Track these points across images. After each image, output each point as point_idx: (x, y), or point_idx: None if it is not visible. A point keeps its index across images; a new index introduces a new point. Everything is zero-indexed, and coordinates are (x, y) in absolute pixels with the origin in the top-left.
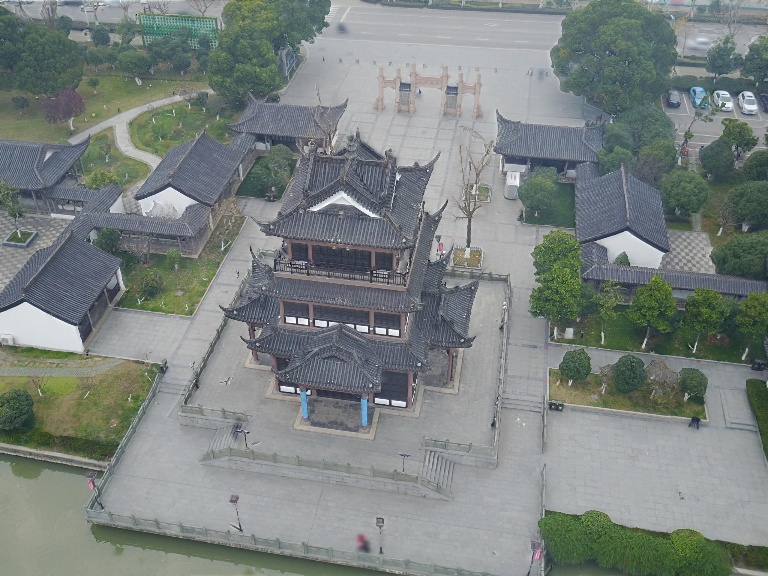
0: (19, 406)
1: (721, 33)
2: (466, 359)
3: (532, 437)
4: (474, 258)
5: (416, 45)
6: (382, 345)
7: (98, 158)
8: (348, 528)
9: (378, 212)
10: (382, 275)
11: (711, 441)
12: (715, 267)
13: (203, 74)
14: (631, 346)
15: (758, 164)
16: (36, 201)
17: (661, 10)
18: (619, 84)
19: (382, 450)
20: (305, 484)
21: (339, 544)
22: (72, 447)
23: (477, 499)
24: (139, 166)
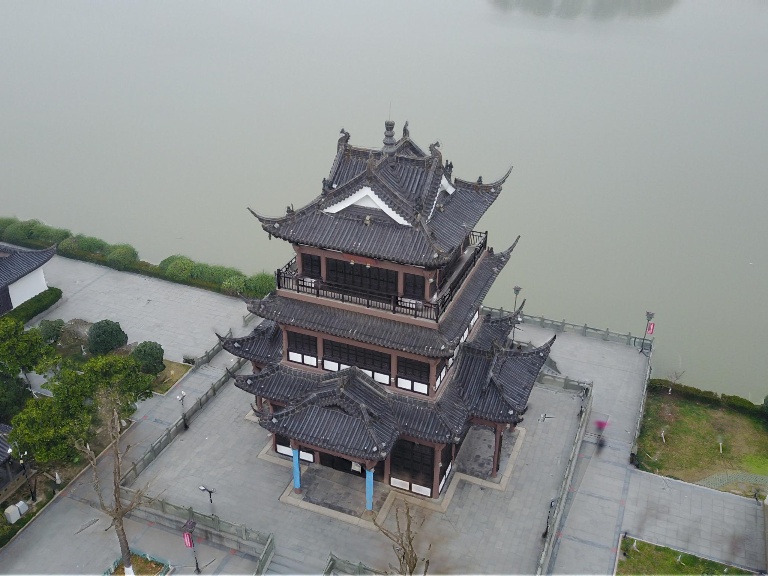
0: None
1: None
2: None
3: None
4: (123, 575)
5: None
6: None
7: None
8: None
9: None
10: None
11: None
12: None
13: None
14: None
15: None
16: None
17: None
18: None
19: None
20: None
21: None
22: None
23: None
24: None
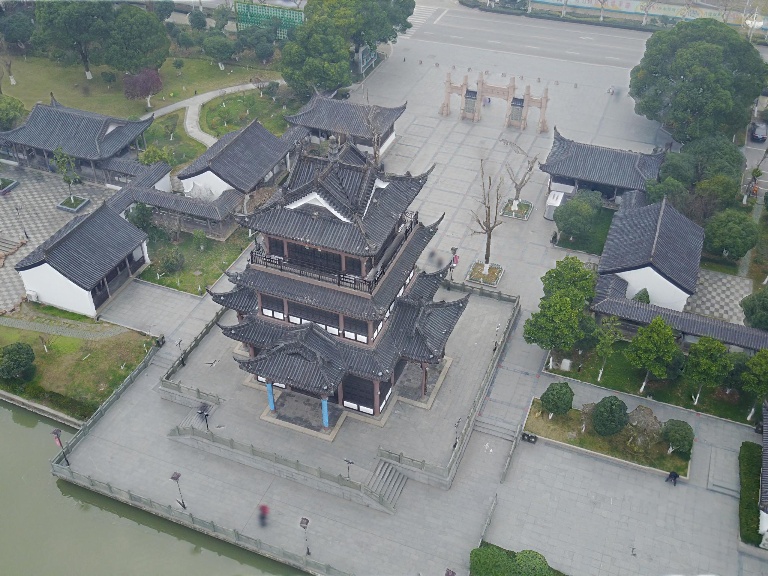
0: (18, 358)
1: None
2: (449, 376)
3: (495, 465)
4: (492, 275)
5: (502, 53)
6: (350, 349)
7: (164, 136)
8: (285, 523)
9: (349, 217)
10: (349, 280)
11: (685, 500)
12: None
13: None
14: (629, 387)
15: None
16: (94, 170)
17: (763, 37)
18: (690, 112)
19: (337, 453)
20: (257, 474)
21: (271, 537)
22: (58, 403)
23: (419, 518)
24: (199, 147)
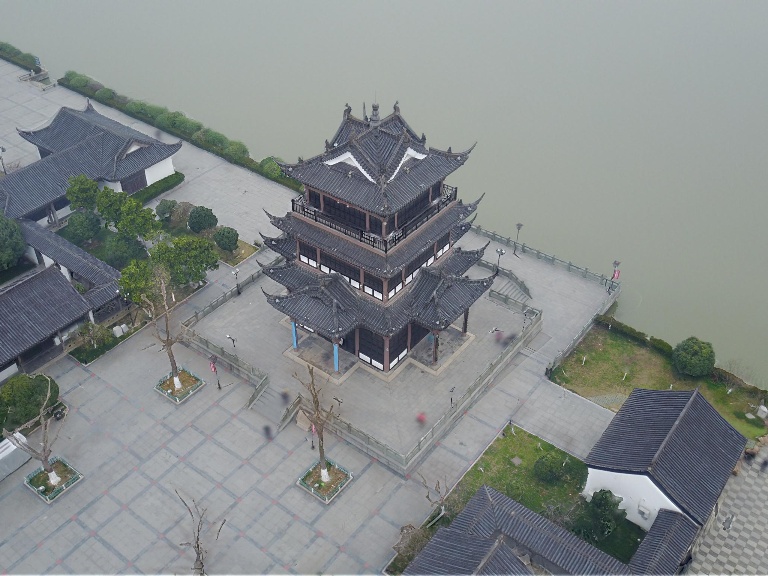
0: None
1: None
2: None
3: None
4: None
5: None
6: None
7: None
8: None
9: None
10: None
11: None
12: None
13: None
14: None
15: None
16: None
17: None
18: None
19: None
20: None
21: None
22: None
23: None
24: None
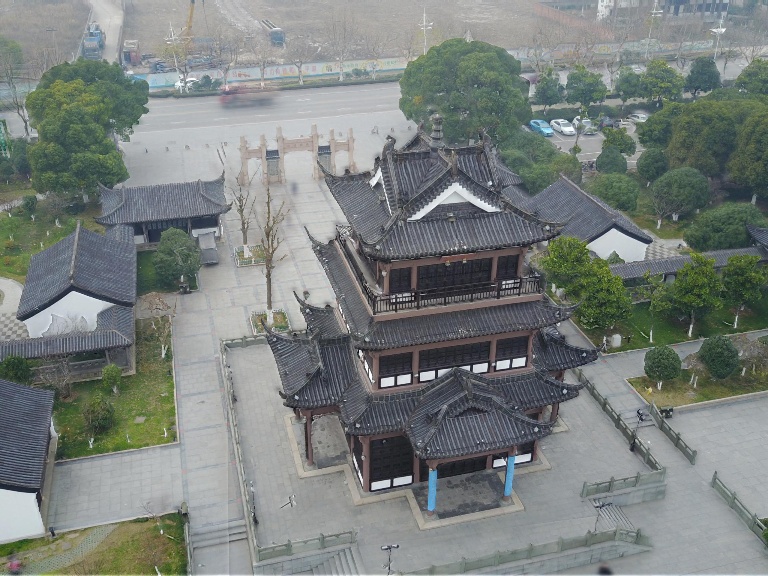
0: None
1: (534, 71)
2: None
3: (668, 452)
4: None
5: (240, 125)
6: (506, 383)
7: None
8: None
9: (497, 204)
10: (512, 285)
11: None
12: (680, 254)
13: (6, 184)
14: (678, 338)
15: (654, 161)
16: None
17: None
18: (495, 114)
19: (543, 518)
20: None
21: None
22: None
23: (676, 537)
24: None
